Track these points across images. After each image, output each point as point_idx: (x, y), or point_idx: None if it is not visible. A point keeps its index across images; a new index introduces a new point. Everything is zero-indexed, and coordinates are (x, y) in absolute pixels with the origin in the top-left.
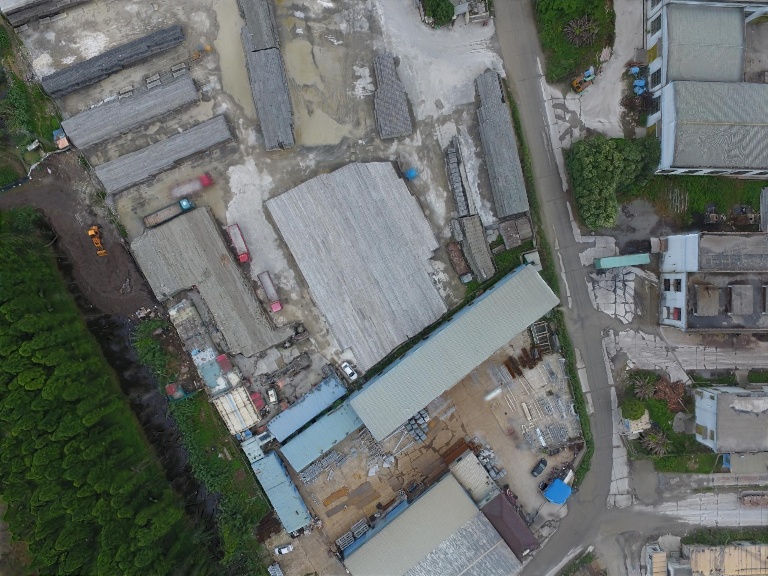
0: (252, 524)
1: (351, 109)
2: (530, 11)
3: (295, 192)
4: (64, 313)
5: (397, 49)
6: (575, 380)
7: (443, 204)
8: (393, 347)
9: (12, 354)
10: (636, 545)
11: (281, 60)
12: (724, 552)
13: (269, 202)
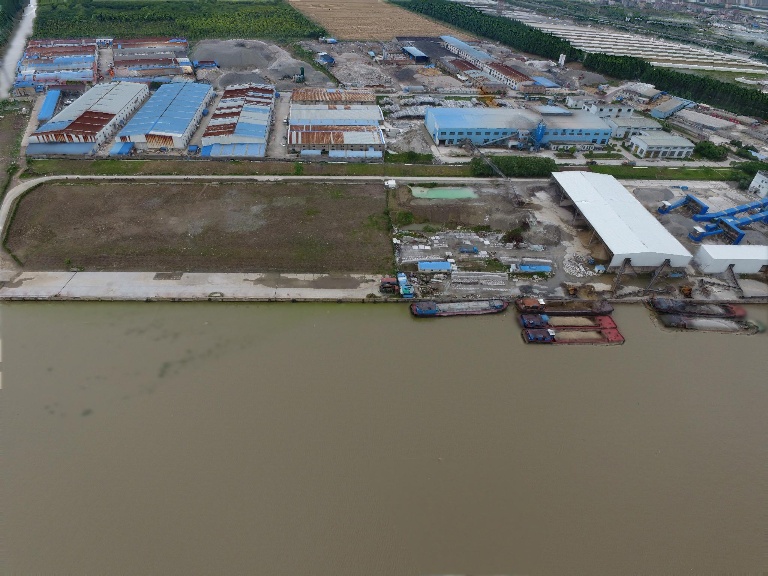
0: (684, 98)
1: None
2: None
3: (732, 124)
4: (759, 113)
5: None
6: None
7: None
8: None
9: (762, 98)
10: None
11: (762, 138)
12: (571, 92)
13: None
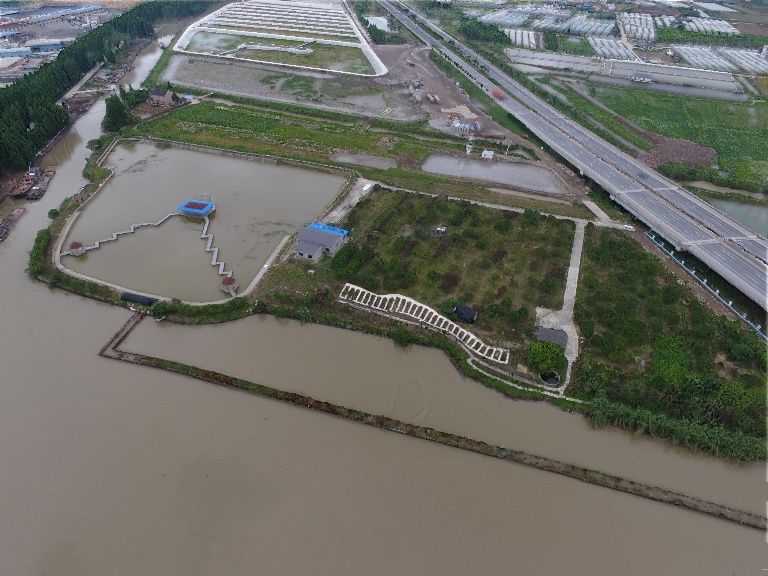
0: None
1: None
2: None
3: None
4: None
5: None
6: None
7: None
8: (12, 57)
9: None
10: (7, 46)
11: None
12: None
13: (5, 67)
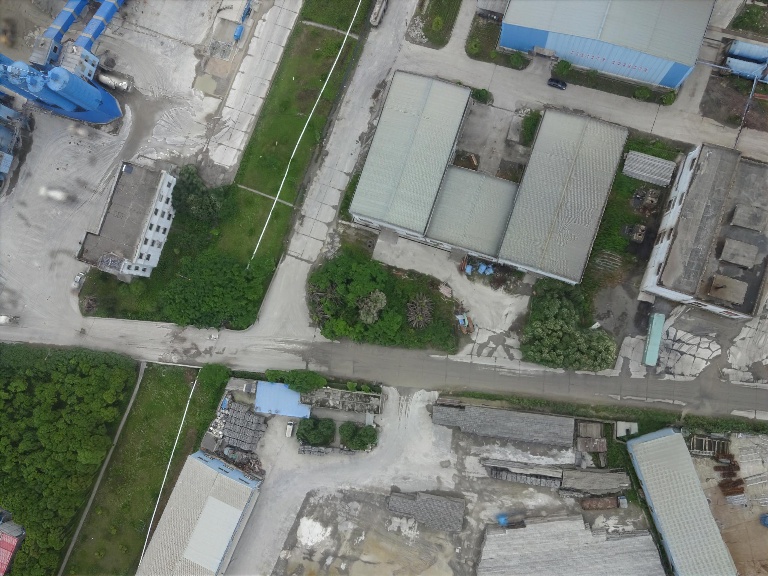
0: None
1: (425, 547)
2: (386, 349)
3: None
4: None
5: (384, 484)
6: (767, 429)
7: (540, 495)
8: None
9: None
10: None
11: None
12: None
13: None
